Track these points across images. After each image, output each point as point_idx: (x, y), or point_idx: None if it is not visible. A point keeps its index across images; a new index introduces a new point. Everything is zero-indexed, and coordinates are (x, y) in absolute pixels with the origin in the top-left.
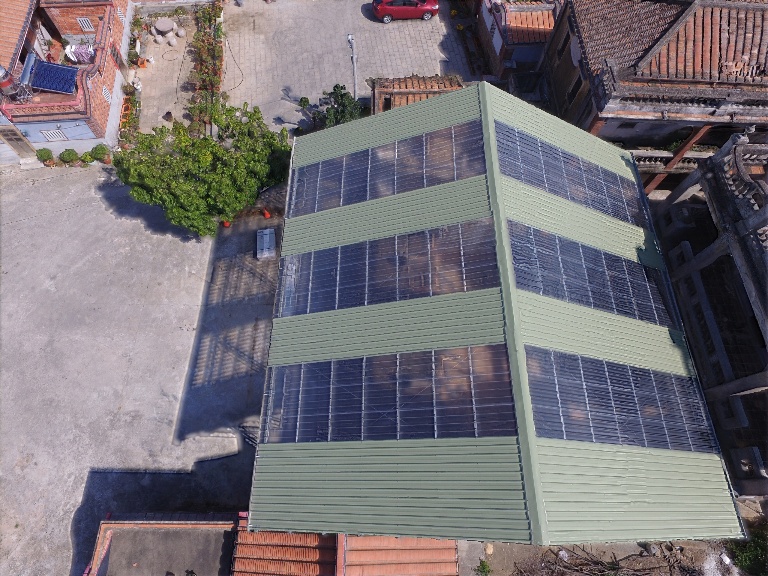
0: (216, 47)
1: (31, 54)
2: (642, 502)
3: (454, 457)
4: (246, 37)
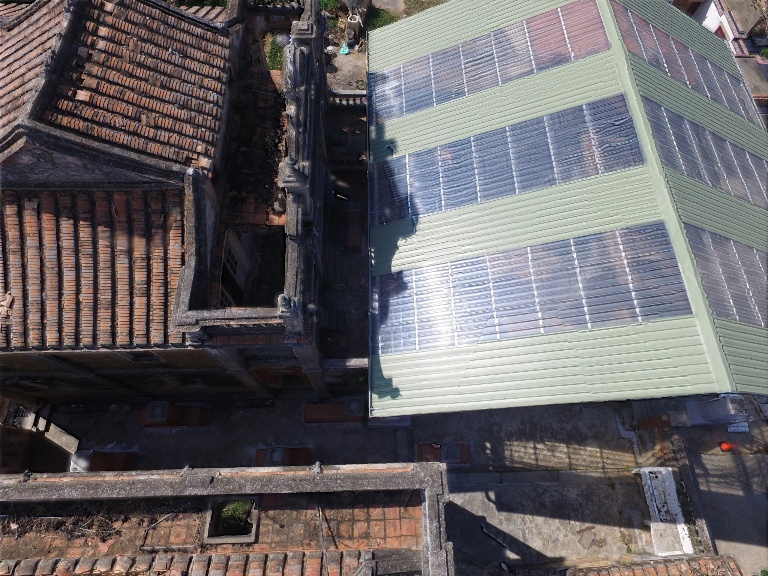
0: None
1: None
2: (477, 8)
3: (638, 8)
4: None
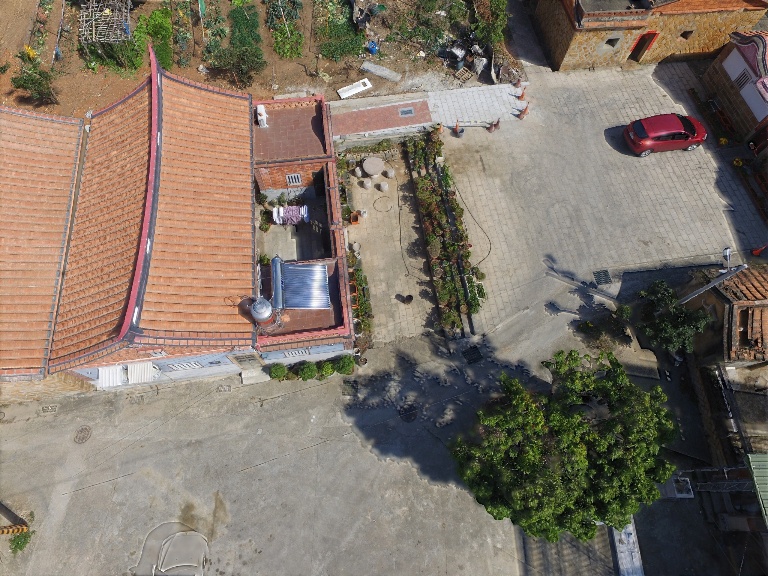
0: (453, 203)
1: (275, 258)
2: None
3: None
4: (478, 182)
